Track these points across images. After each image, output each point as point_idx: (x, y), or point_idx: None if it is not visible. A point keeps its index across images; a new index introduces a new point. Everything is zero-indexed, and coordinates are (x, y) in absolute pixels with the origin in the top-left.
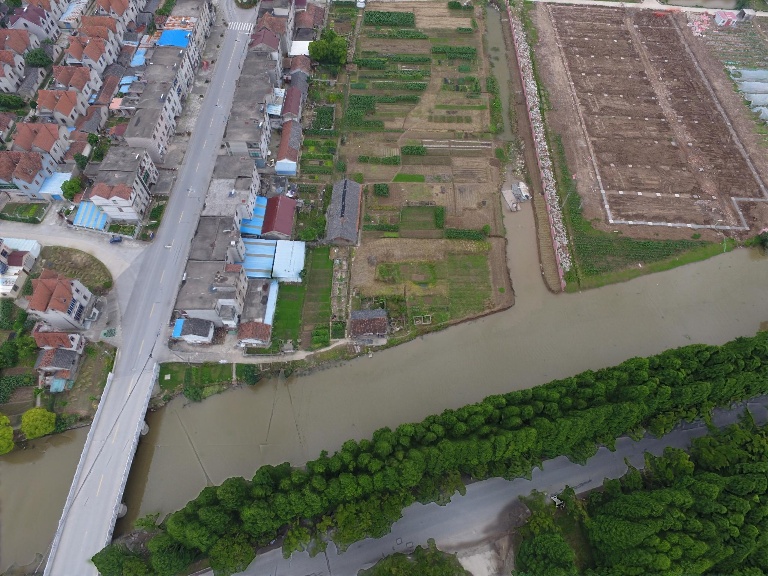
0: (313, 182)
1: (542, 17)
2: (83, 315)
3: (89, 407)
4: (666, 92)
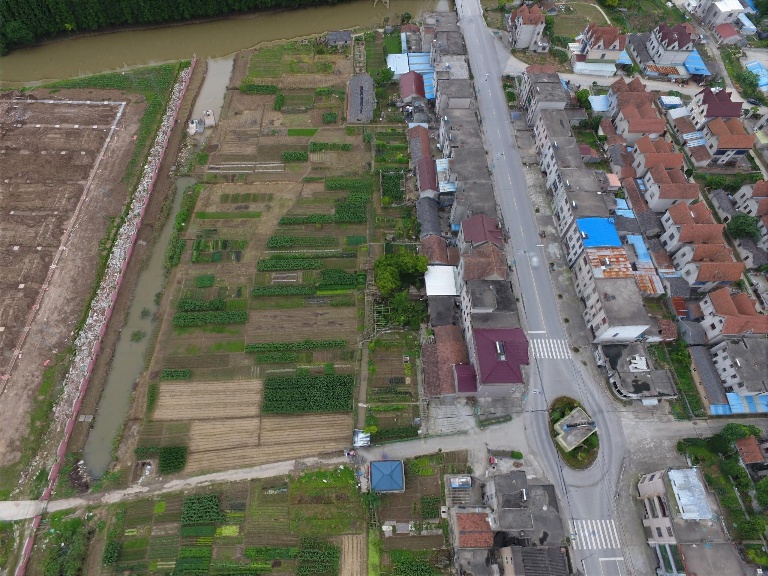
0: (392, 126)
1: (0, 439)
2: (514, 31)
3: None
4: None
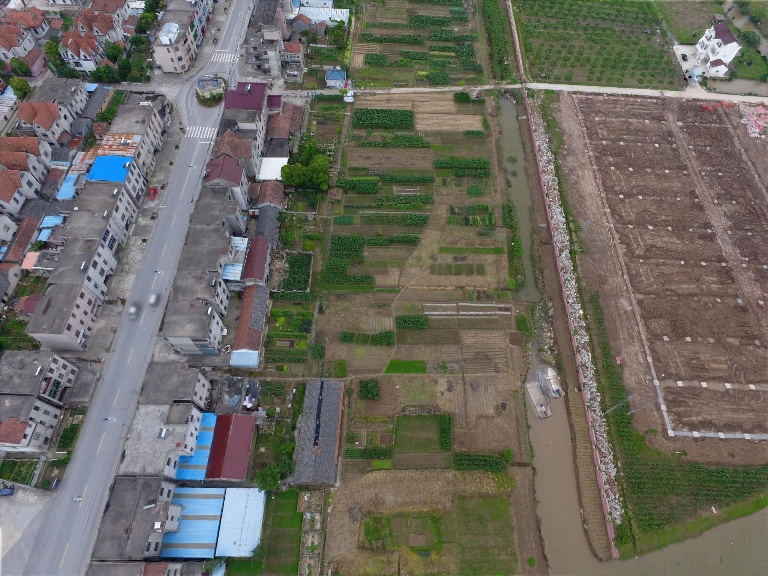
0: (280, 376)
1: (567, 112)
2: None
3: None
4: (724, 221)
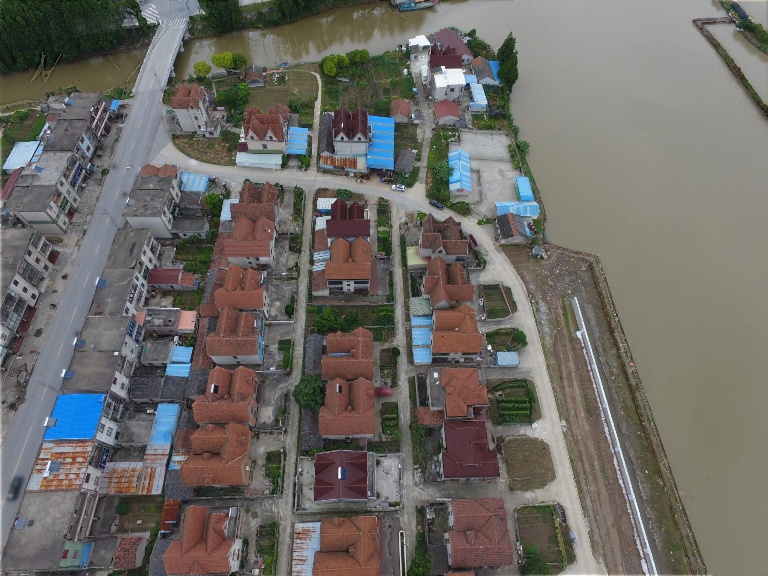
0: None
1: None
2: None
3: None
4: None
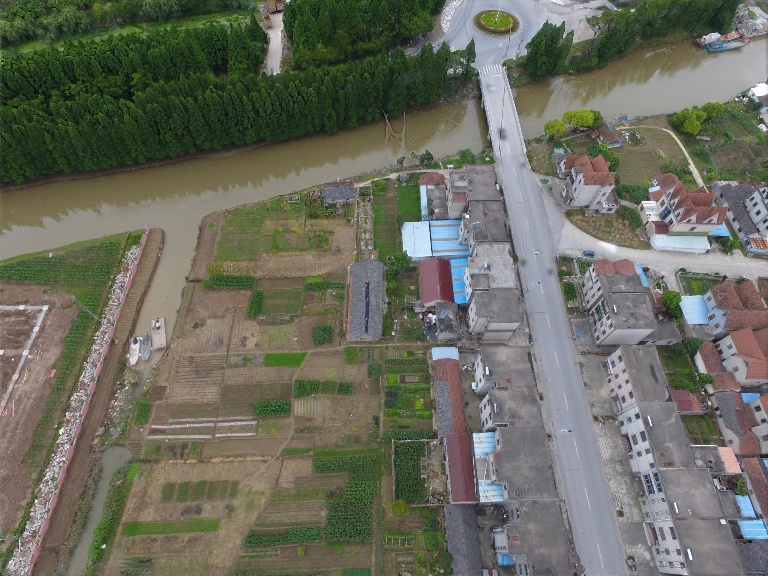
0: (409, 346)
1: None
2: None
3: (532, 147)
4: None
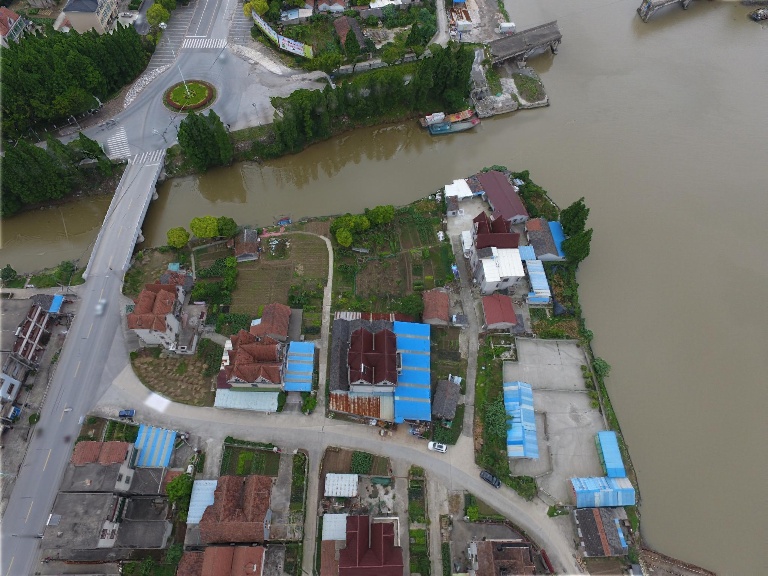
0: None
1: None
2: None
3: (153, 258)
4: None
